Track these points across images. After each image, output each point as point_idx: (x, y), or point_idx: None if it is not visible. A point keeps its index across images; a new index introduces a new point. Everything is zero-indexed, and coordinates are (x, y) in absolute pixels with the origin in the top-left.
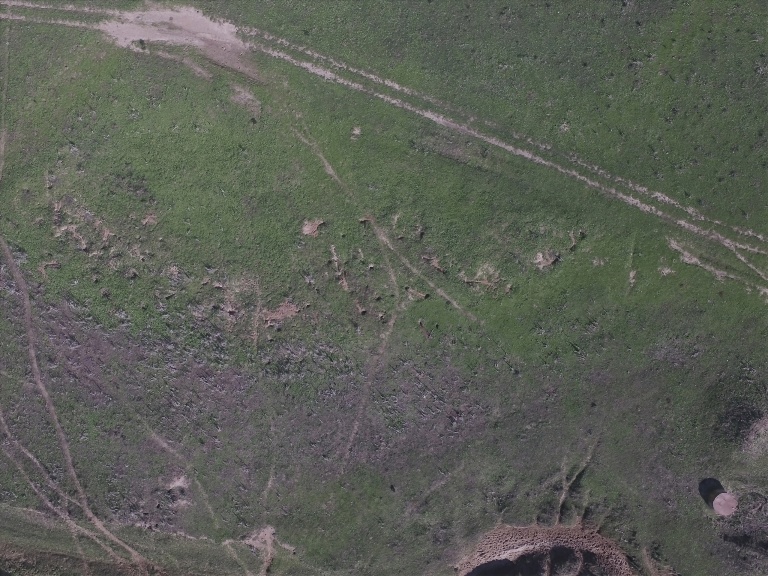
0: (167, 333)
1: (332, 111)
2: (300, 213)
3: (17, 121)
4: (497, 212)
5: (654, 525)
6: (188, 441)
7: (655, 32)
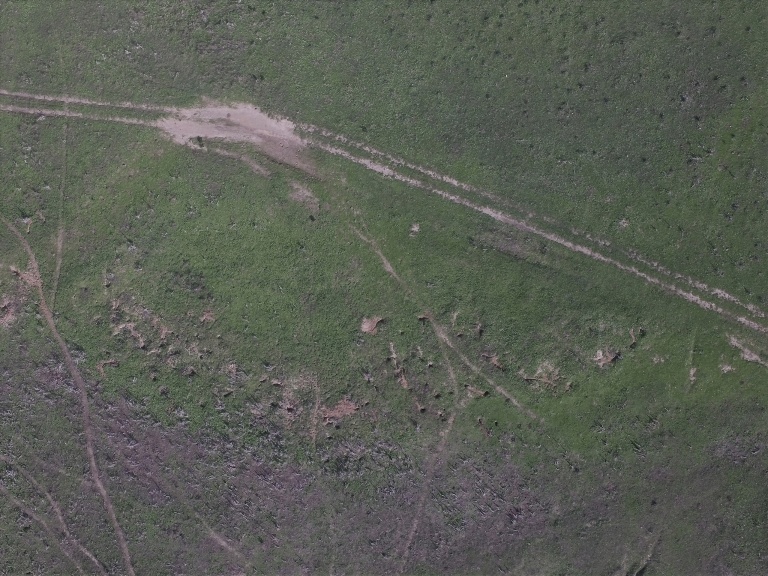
0: (226, 431)
1: (390, 208)
2: (359, 310)
3: (75, 219)
4: (556, 309)
5: None
6: (247, 539)
7: (714, 127)
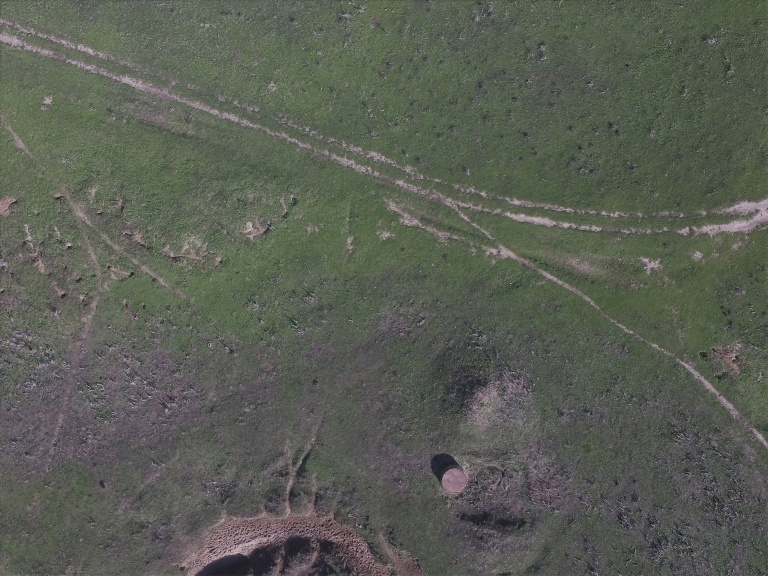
0: None
1: (20, 81)
2: None
3: None
4: (202, 181)
5: (386, 508)
6: None
7: None
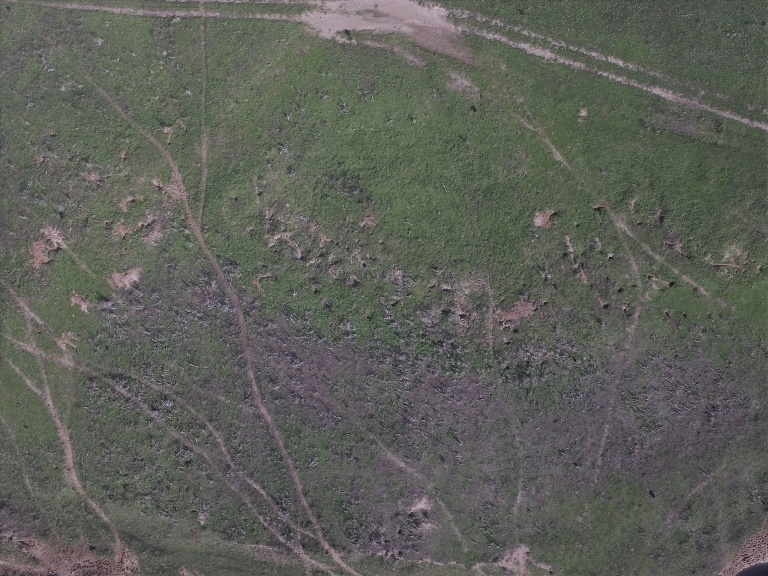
0: (396, 343)
1: (555, 93)
2: (530, 204)
3: (219, 125)
4: (740, 189)
5: None
6: (427, 458)
7: None
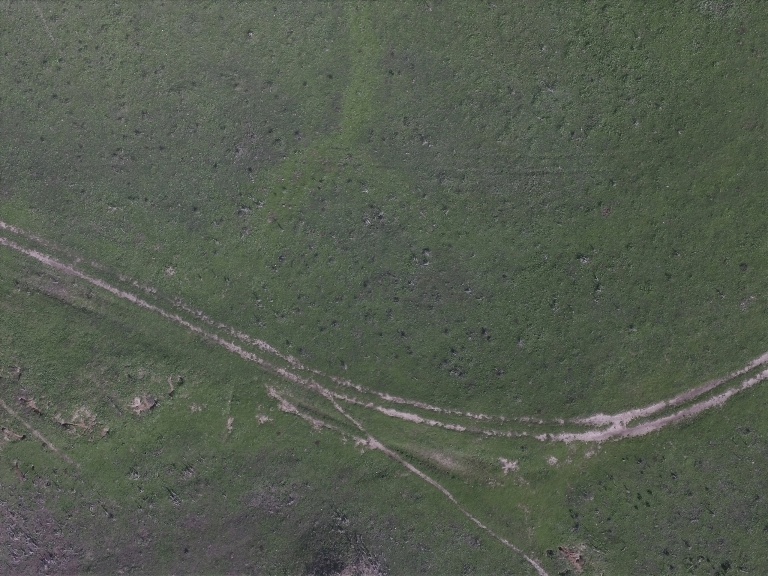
0: None
1: None
2: None
3: None
4: (97, 355)
5: None
6: None
7: (267, 179)
